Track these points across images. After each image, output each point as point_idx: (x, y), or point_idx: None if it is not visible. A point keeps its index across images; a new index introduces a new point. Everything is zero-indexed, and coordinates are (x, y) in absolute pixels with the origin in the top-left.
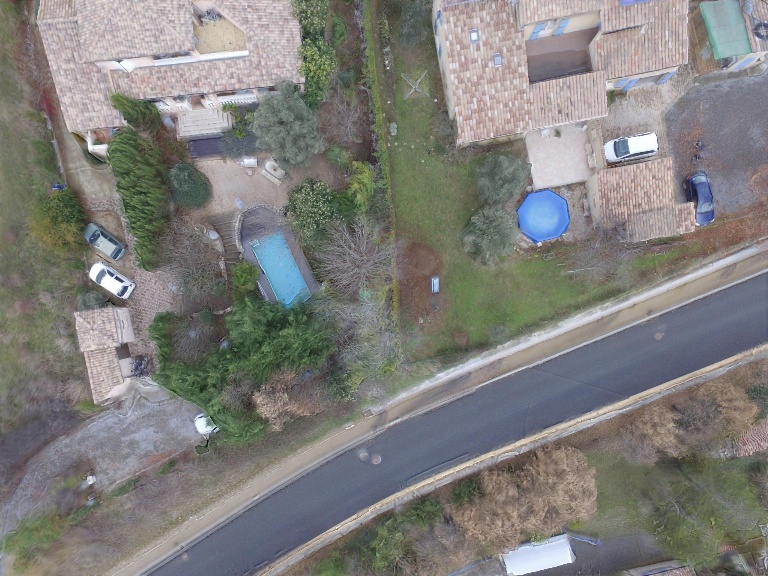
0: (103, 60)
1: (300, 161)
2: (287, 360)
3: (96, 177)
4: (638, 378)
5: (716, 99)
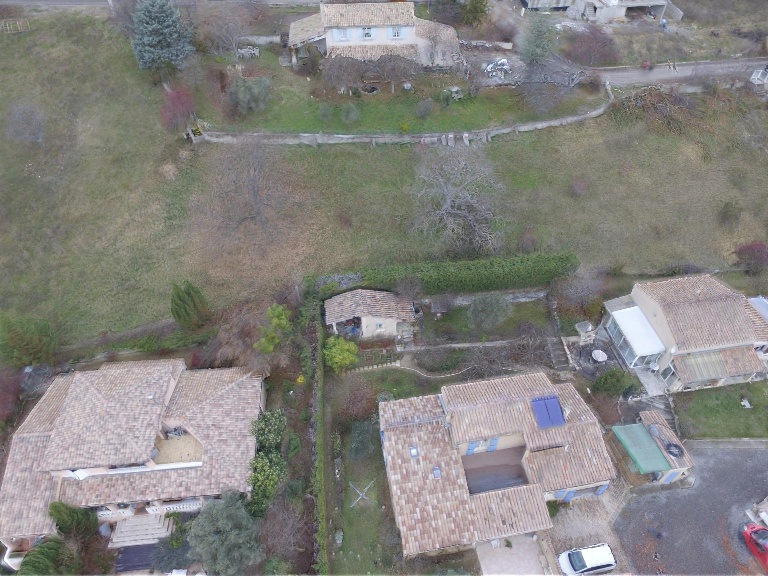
0: (58, 470)
1: (231, 574)
2: None
3: None
4: None
5: (658, 509)
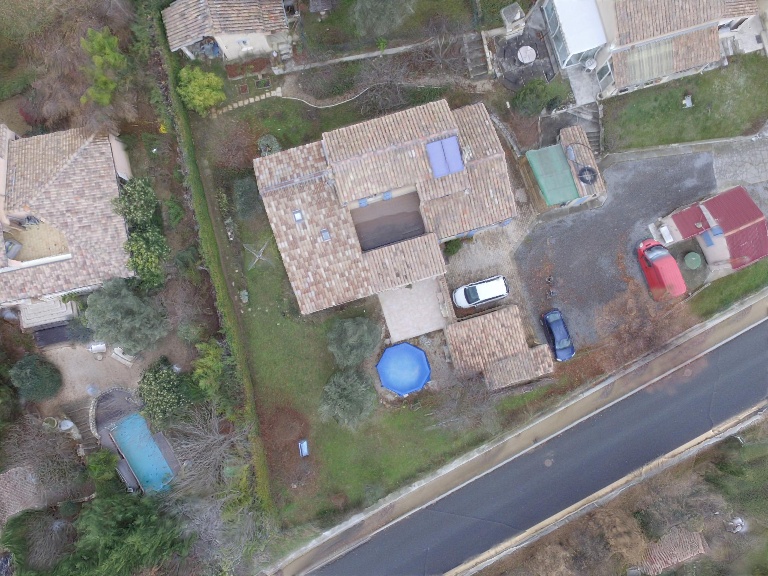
0: None
1: (142, 349)
2: (146, 557)
3: None
4: (534, 508)
5: (561, 234)
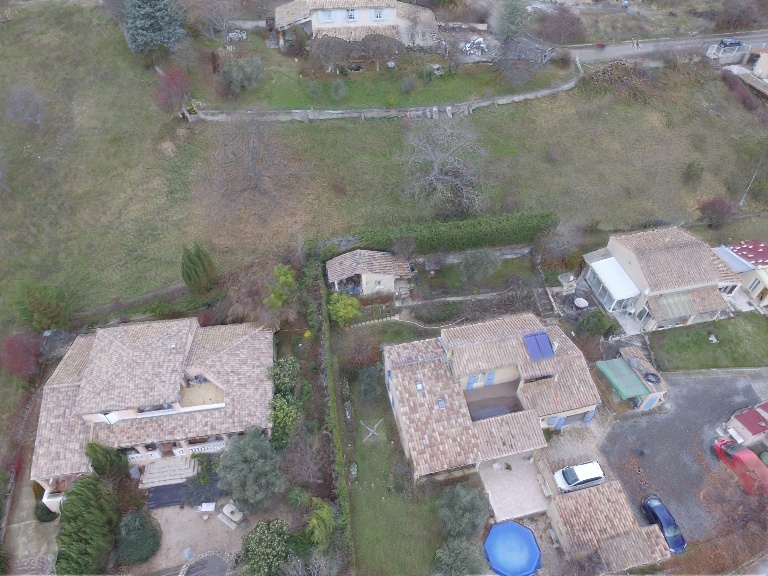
0: (91, 413)
1: (259, 500)
2: None
3: (38, 530)
4: None
5: (639, 432)
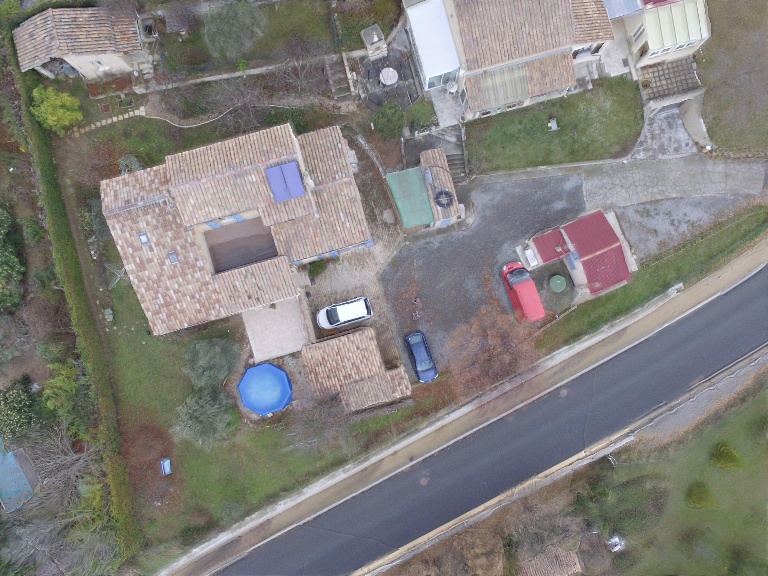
0: None
1: None
2: None
3: None
4: (409, 526)
5: (428, 255)
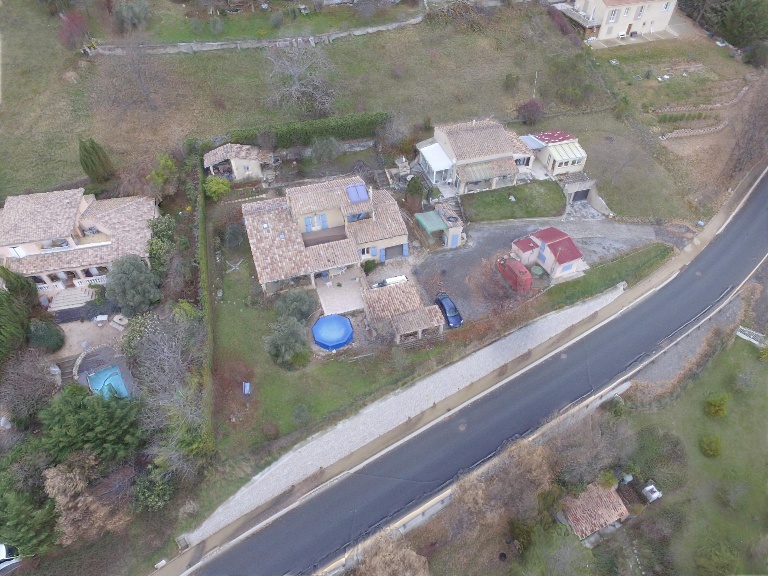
0: (2, 245)
1: (138, 303)
2: (87, 444)
3: None
4: (454, 466)
5: (445, 261)
